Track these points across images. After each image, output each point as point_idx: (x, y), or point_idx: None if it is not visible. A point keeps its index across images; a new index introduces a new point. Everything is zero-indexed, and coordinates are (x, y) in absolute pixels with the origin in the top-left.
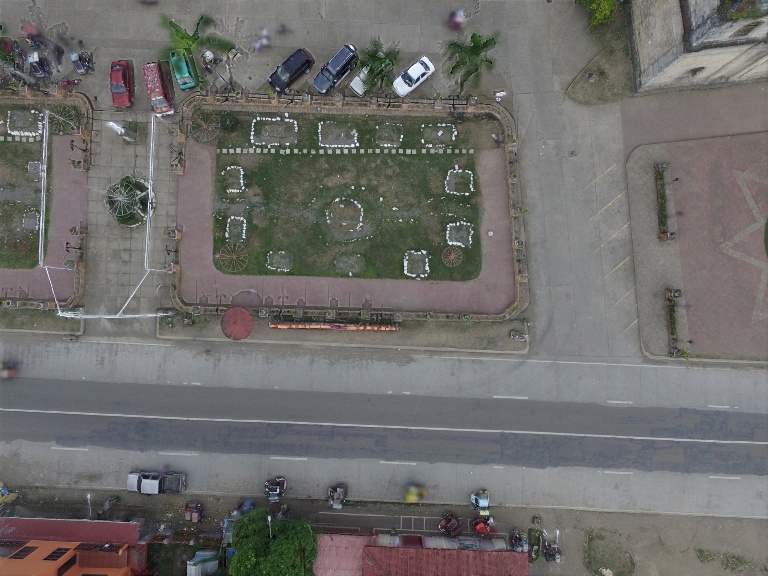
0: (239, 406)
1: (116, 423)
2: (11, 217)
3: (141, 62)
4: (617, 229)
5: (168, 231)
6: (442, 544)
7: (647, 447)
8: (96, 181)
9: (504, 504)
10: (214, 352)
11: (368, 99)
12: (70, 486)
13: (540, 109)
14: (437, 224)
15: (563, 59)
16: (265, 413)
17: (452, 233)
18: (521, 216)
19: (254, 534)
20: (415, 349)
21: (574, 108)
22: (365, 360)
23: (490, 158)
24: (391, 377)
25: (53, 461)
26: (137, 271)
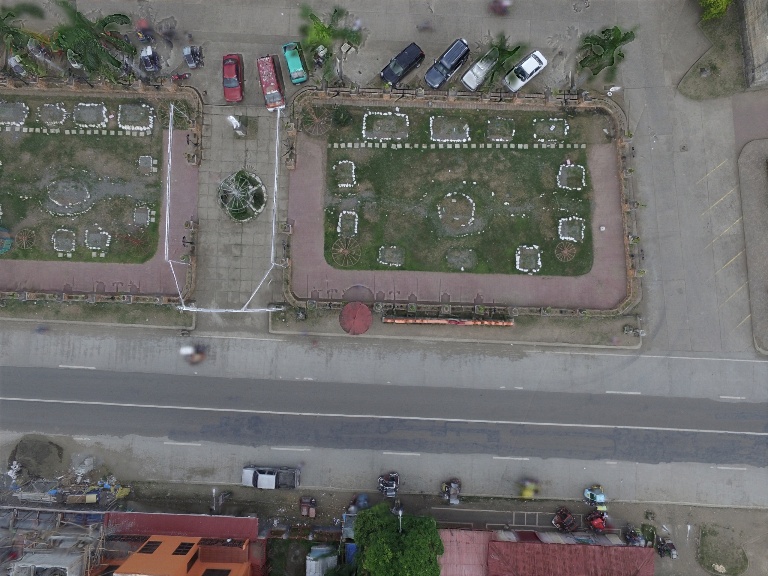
0: (352, 401)
1: (228, 418)
2: (122, 211)
3: (250, 56)
4: (729, 224)
5: (284, 225)
6: (559, 539)
7: (760, 443)
8: (207, 175)
9: (617, 500)
10: (326, 347)
11: (479, 94)
12: (182, 481)
13: (651, 104)
14: (549, 219)
15: (674, 54)
16: (377, 408)
17: (564, 228)
18: (633, 211)
19: (382, 529)
20: (528, 344)
21: (685, 103)
22: (477, 355)
23: (601, 153)
24: (504, 372)
25: (165, 456)
26: (248, 266)
